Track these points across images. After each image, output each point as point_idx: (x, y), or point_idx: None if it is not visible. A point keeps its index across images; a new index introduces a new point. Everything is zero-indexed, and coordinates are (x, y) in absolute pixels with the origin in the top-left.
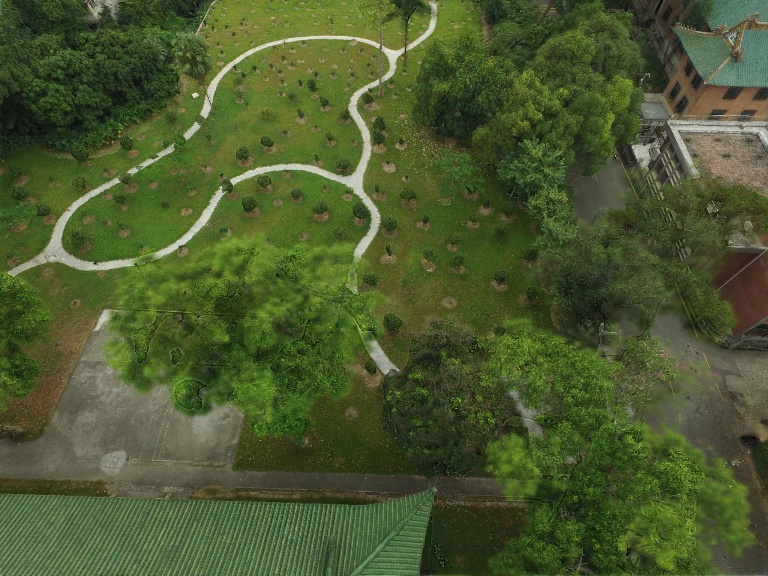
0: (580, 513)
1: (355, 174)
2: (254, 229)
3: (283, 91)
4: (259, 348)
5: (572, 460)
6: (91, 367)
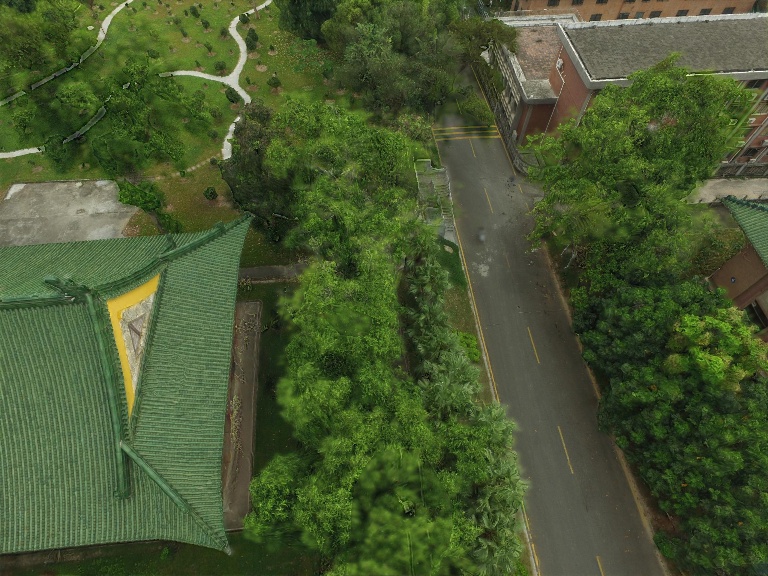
0: None
1: (232, 75)
2: None
3: (171, 20)
4: None
5: None
6: (4, 223)
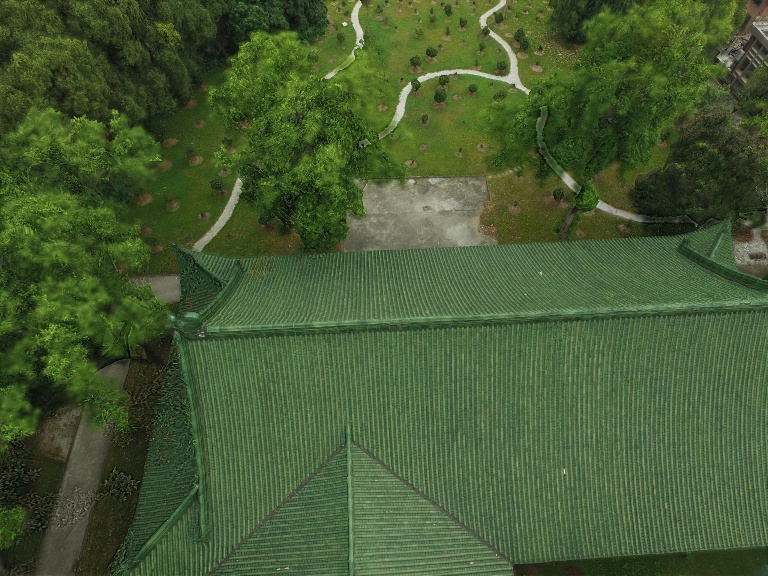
0: None
1: (511, 74)
2: (447, 116)
3: (419, 18)
4: (489, 196)
5: (759, 250)
6: (357, 219)
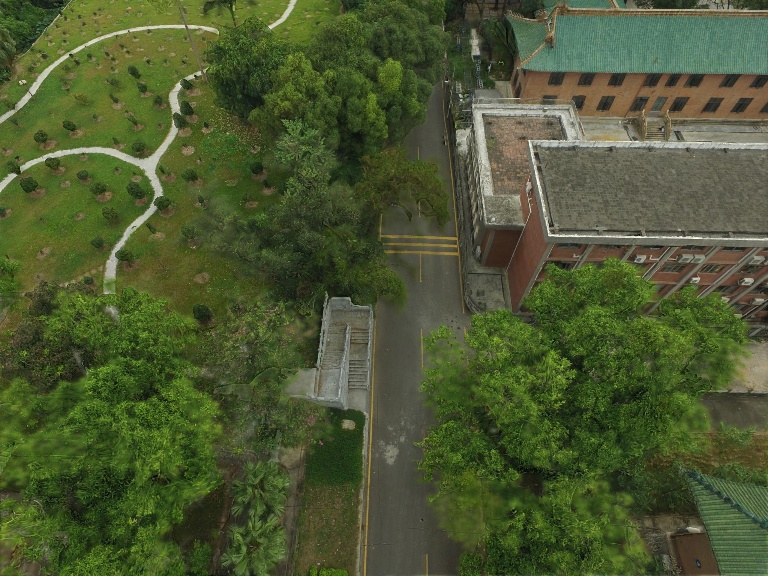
0: (86, 454)
1: (152, 157)
2: (34, 209)
3: None
4: (2, 322)
5: None
6: None
